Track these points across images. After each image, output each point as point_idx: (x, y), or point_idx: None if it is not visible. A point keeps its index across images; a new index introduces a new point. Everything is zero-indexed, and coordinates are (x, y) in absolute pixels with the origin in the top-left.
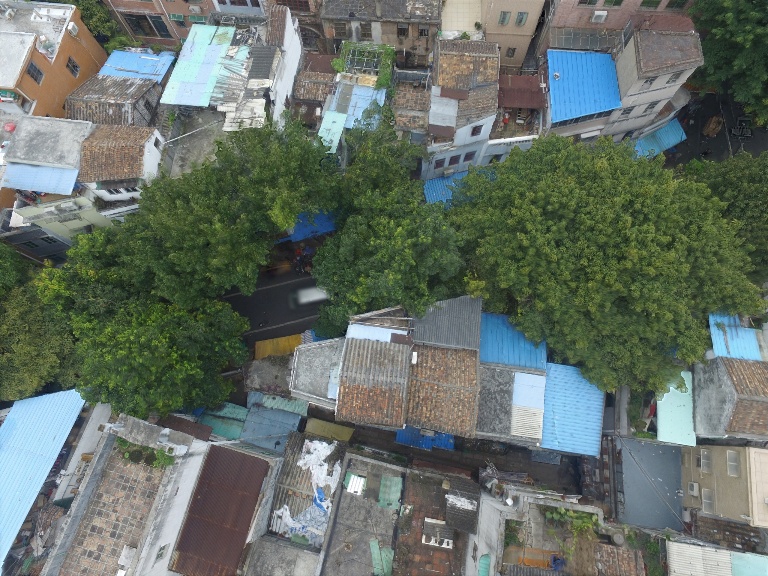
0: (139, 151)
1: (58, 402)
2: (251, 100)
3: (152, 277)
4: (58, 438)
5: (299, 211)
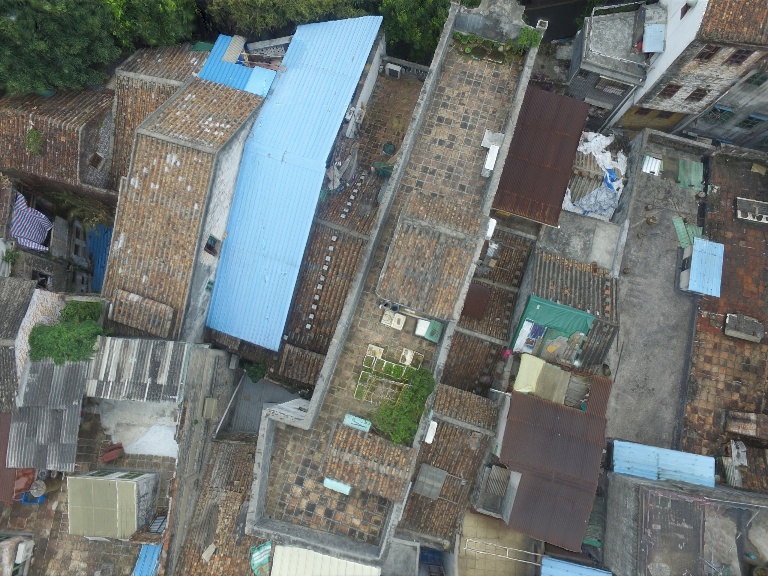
0: None
1: (348, 28)
2: None
3: None
4: (356, 60)
5: None
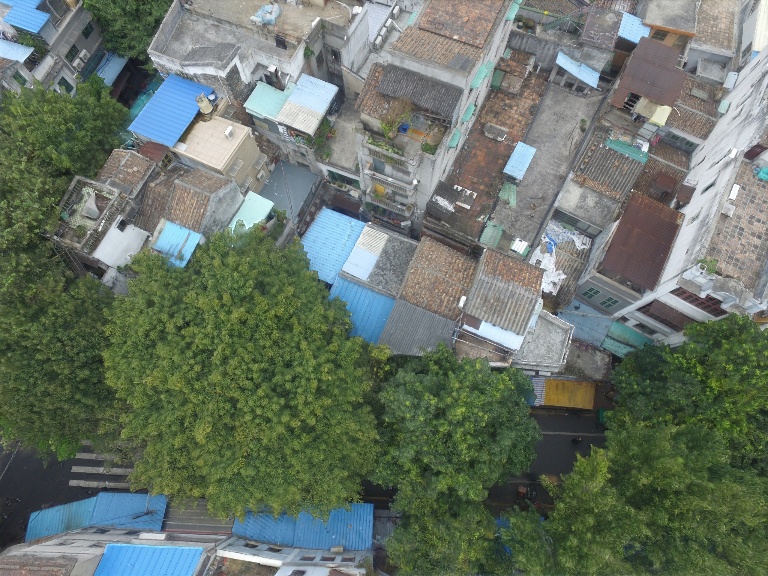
0: None
1: None
2: None
3: None
4: None
5: None
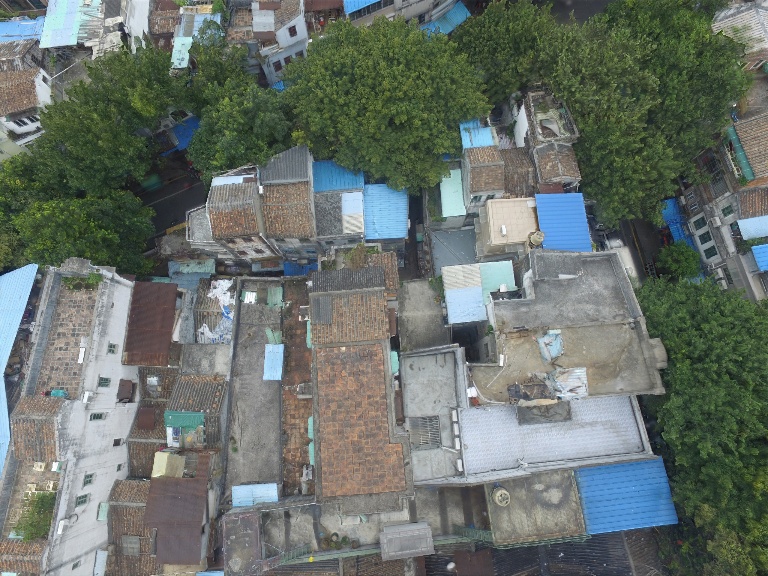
0: (31, 85)
1: (17, 276)
2: (109, 34)
3: (67, 181)
4: (23, 297)
5: (158, 104)
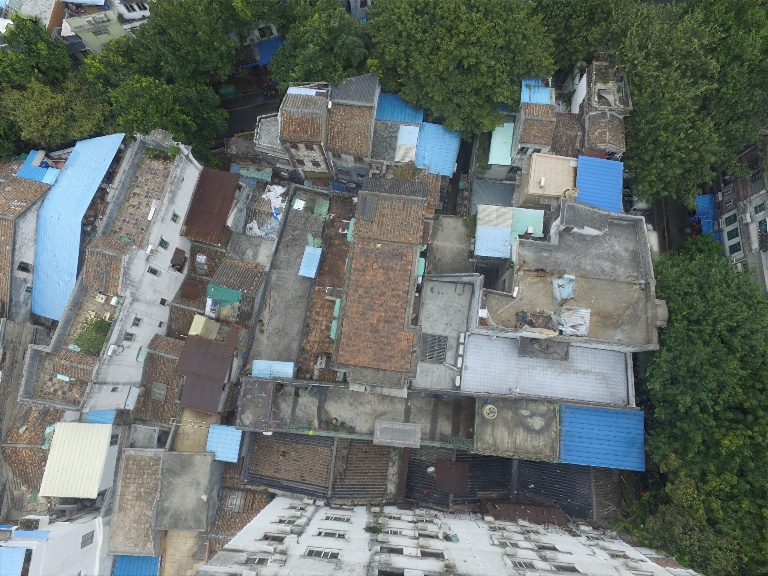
0: None
1: (105, 141)
2: None
3: (160, 68)
4: (107, 160)
5: None
